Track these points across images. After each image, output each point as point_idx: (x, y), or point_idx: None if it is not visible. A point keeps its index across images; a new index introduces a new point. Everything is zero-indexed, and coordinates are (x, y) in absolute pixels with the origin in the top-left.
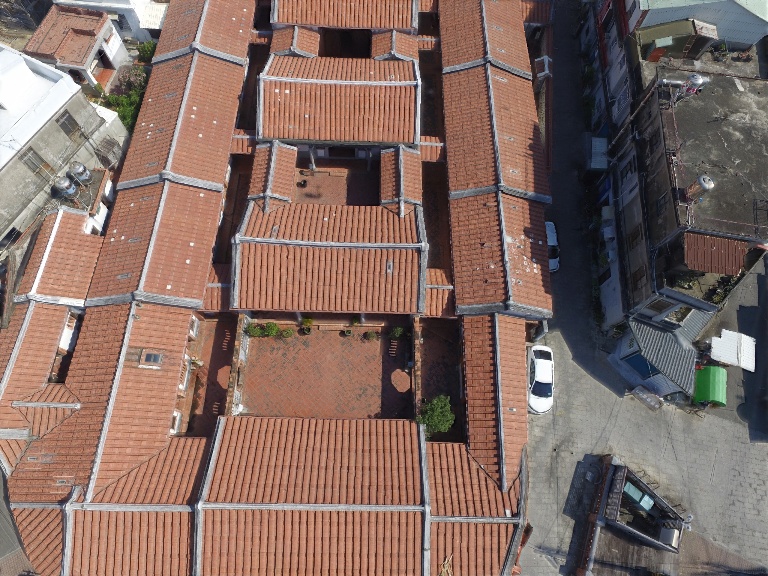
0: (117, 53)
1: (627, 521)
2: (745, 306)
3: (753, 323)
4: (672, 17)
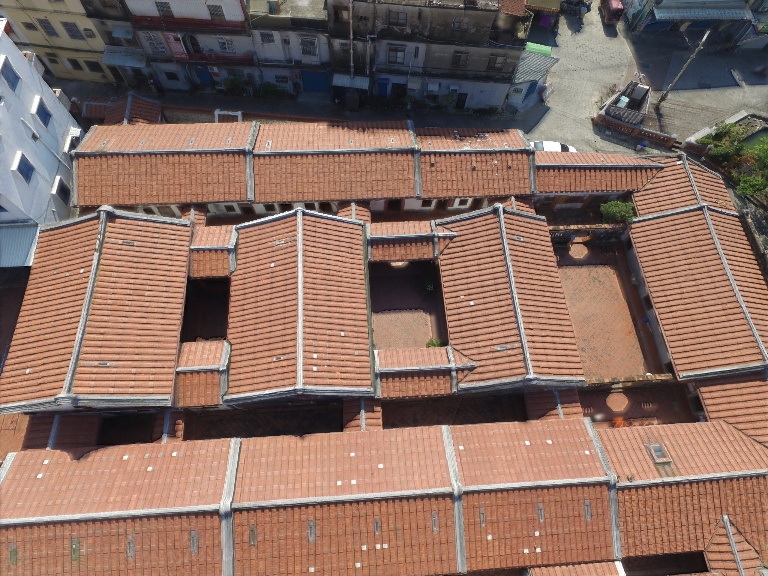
0: None
1: None
2: None
3: None
4: None
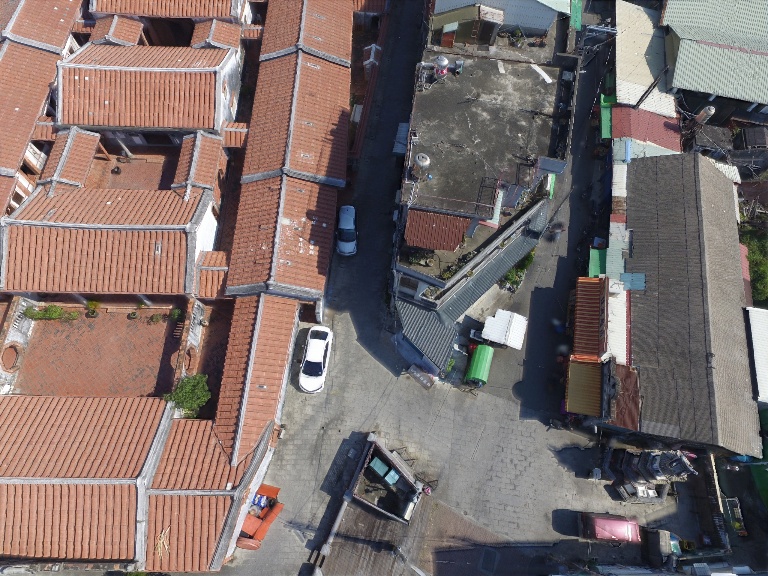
0: None
1: (380, 496)
2: (540, 287)
3: (545, 304)
4: (461, 3)
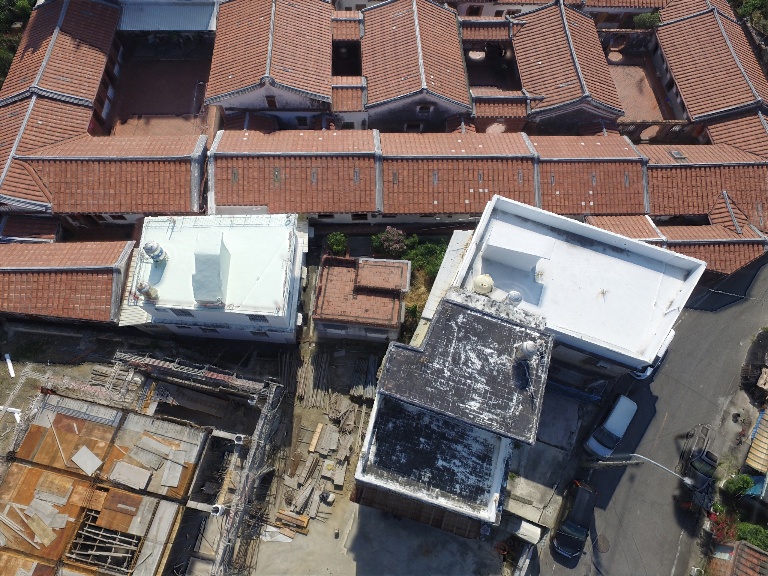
0: None
1: None
2: None
3: None
4: None
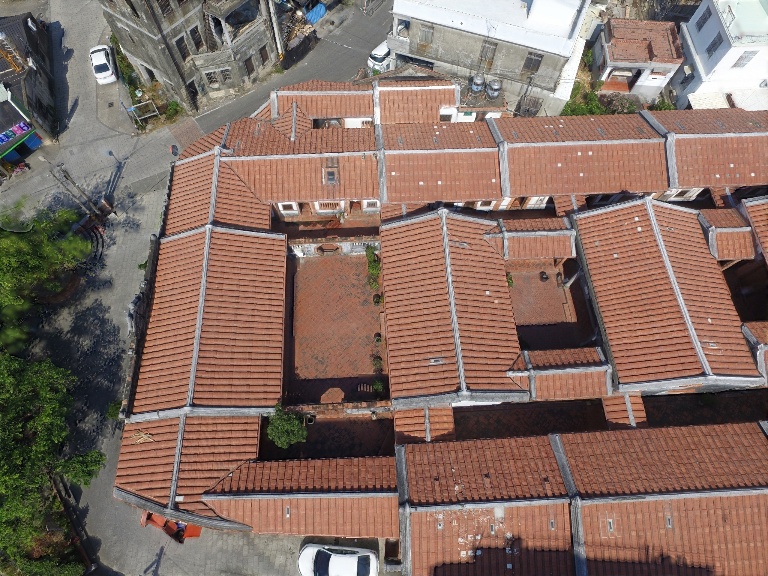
0: (648, 87)
1: None
2: None
3: None
4: None
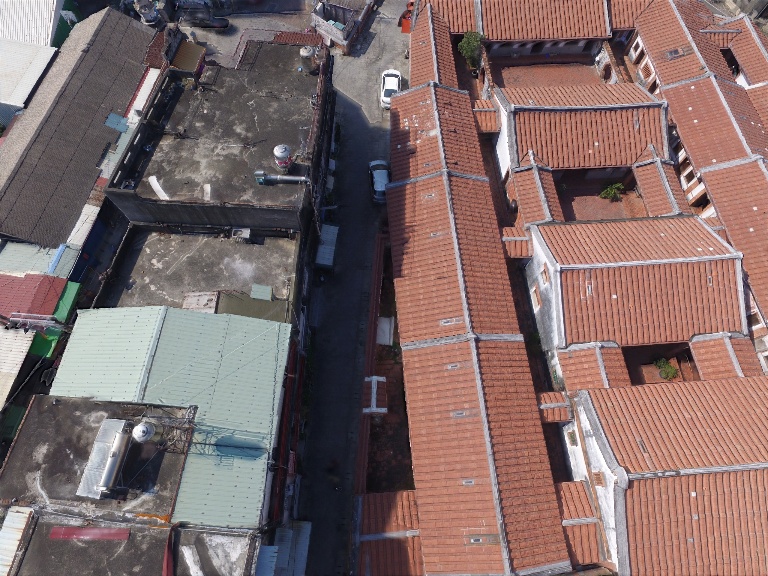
0: None
1: None
2: None
3: None
4: None
